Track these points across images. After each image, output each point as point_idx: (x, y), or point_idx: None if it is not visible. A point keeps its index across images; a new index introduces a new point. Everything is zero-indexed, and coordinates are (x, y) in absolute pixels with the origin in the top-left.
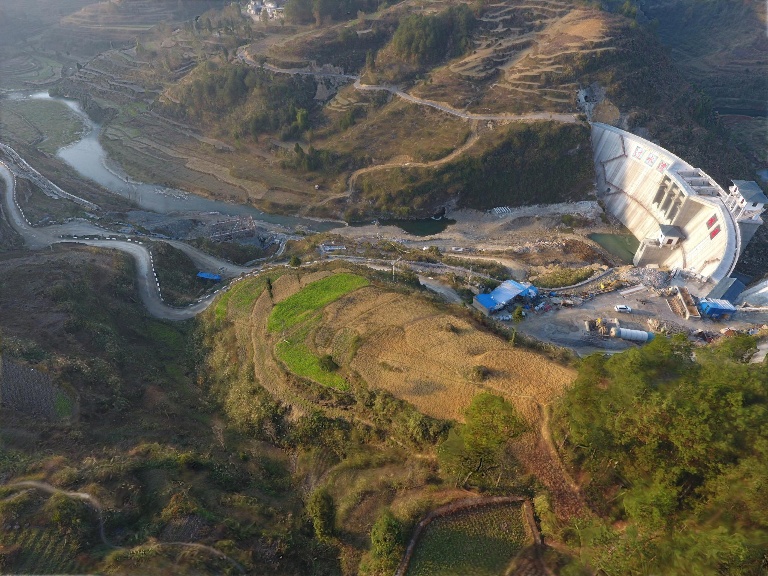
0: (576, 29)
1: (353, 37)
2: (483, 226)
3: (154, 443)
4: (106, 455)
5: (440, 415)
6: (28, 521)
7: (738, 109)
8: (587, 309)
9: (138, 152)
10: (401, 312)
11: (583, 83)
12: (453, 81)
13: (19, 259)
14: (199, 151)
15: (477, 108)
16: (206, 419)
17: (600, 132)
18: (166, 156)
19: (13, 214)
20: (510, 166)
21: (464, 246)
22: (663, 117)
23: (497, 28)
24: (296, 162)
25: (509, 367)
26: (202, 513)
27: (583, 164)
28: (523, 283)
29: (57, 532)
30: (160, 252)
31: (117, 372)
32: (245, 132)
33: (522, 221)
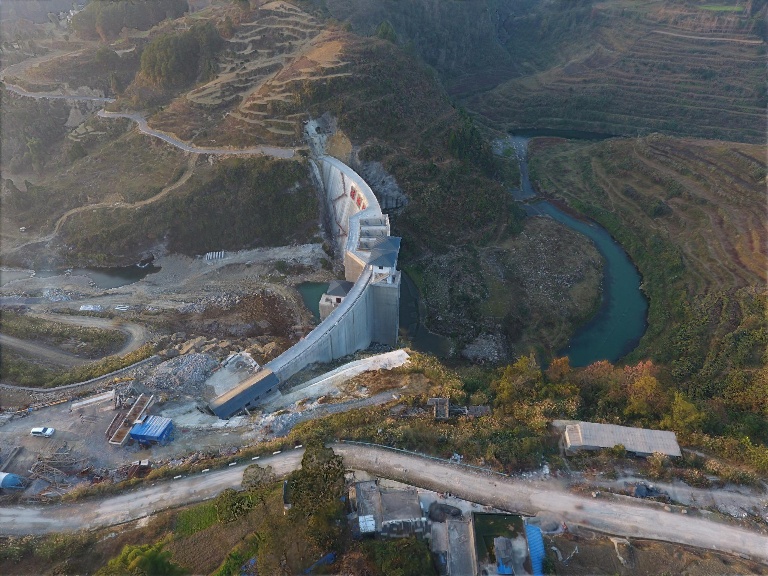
0: (316, 52)
1: (109, 57)
2: (185, 275)
3: None
4: None
5: None
6: None
7: (559, 130)
8: (3, 432)
9: None
10: None
11: (312, 113)
12: (184, 109)
13: None
14: None
15: (203, 140)
16: None
17: (328, 167)
18: None
19: None
20: (221, 207)
21: (136, 303)
22: (405, 149)
23: (245, 50)
24: (6, 200)
25: None
26: None
27: (306, 203)
28: None
29: None
30: None
31: None
32: None
33: (231, 268)
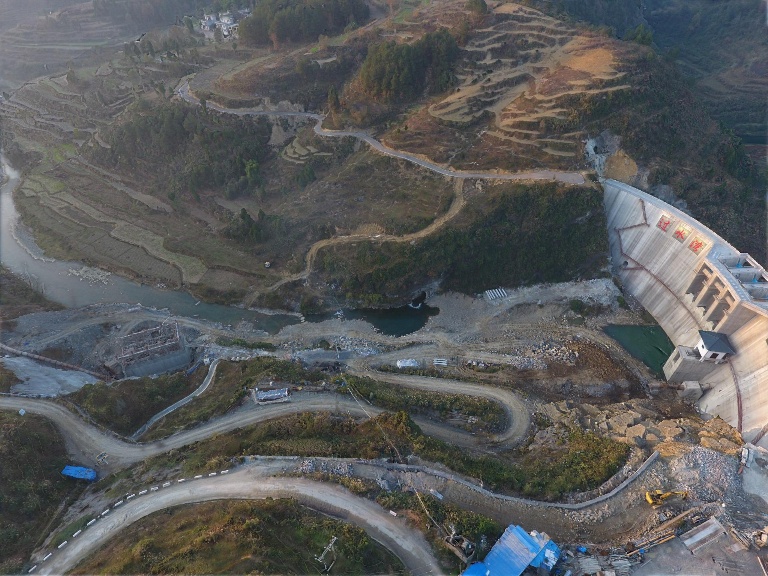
0: (581, 62)
1: (313, 68)
2: (473, 317)
3: None
4: None
5: None
6: None
7: (761, 136)
8: None
9: (56, 214)
10: None
11: (592, 131)
12: (433, 128)
13: None
14: (130, 212)
15: (462, 163)
16: None
17: (614, 192)
18: (89, 220)
19: None
20: (505, 240)
21: (449, 355)
22: (689, 170)
23: (485, 59)
24: (242, 232)
25: None
26: None
27: (594, 234)
28: (535, 535)
29: None
30: None
31: None
32: (185, 188)
33: (521, 309)
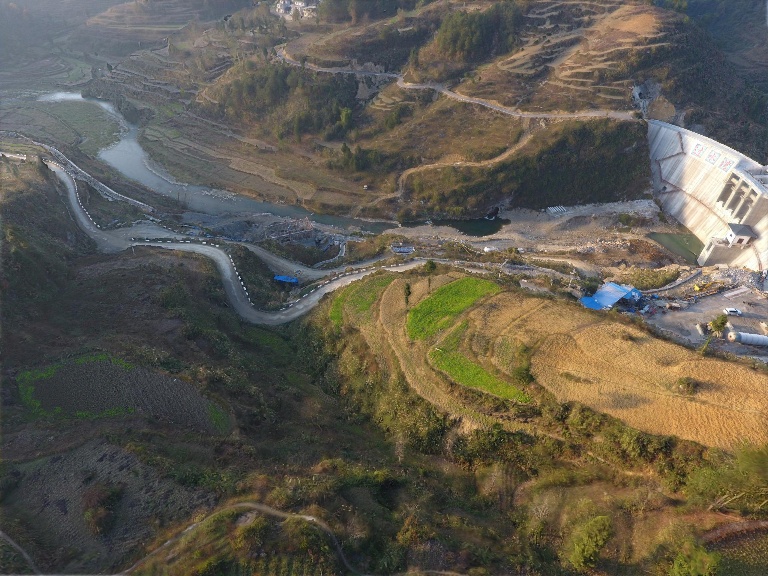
0: (628, 25)
1: (394, 35)
2: (539, 226)
3: (339, 459)
4: (292, 472)
5: (655, 430)
6: (274, 548)
7: None
8: (694, 312)
9: (180, 153)
10: (559, 319)
11: (637, 80)
12: (502, 79)
13: (107, 263)
14: (241, 151)
15: (528, 106)
16: (357, 431)
17: (656, 129)
18: (208, 157)
19: (80, 217)
20: (565, 165)
21: (524, 246)
22: (719, 114)
23: (544, 24)
24: (344, 162)
25: (715, 379)
26: (439, 538)
27: (639, 162)
28: (625, 286)
29: (309, 560)
30: (239, 255)
31: (252, 381)
32: (287, 132)
33: (578, 221)
